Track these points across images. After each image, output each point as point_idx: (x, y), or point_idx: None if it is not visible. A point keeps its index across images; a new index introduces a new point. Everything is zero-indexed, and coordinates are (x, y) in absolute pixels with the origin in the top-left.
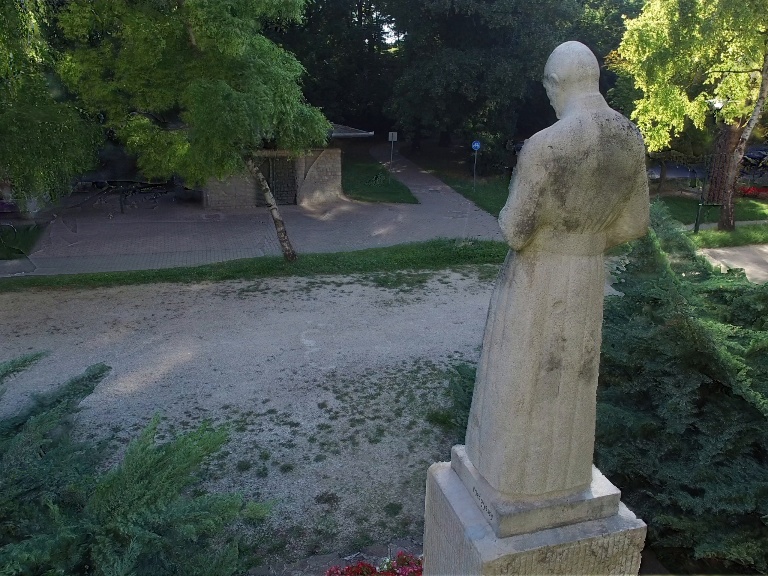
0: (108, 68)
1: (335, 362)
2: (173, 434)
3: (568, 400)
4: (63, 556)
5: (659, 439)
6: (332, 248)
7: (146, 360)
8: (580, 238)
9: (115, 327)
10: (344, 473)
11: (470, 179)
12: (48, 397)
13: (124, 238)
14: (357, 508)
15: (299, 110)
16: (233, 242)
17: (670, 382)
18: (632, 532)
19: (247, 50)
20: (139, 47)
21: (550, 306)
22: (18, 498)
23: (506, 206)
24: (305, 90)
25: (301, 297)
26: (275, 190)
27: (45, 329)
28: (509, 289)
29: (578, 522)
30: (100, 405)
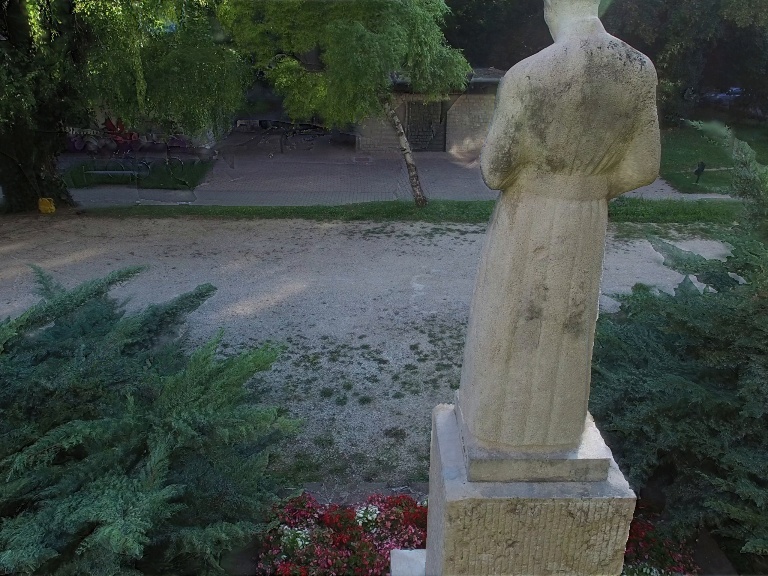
0: (259, 11)
1: (438, 307)
2: None
3: (548, 353)
4: (126, 438)
5: (739, 422)
6: (472, 197)
7: (266, 288)
8: (567, 180)
9: (247, 256)
10: (417, 412)
11: None
12: (160, 308)
13: (279, 176)
14: (421, 446)
15: (438, 52)
16: (376, 185)
17: (760, 361)
18: (617, 501)
19: None
20: None
21: (530, 251)
22: (108, 387)
23: (485, 142)
24: (447, 31)
25: (422, 242)
26: (409, 134)
27: (189, 252)
28: (492, 231)
29: (558, 481)
30: (218, 323)
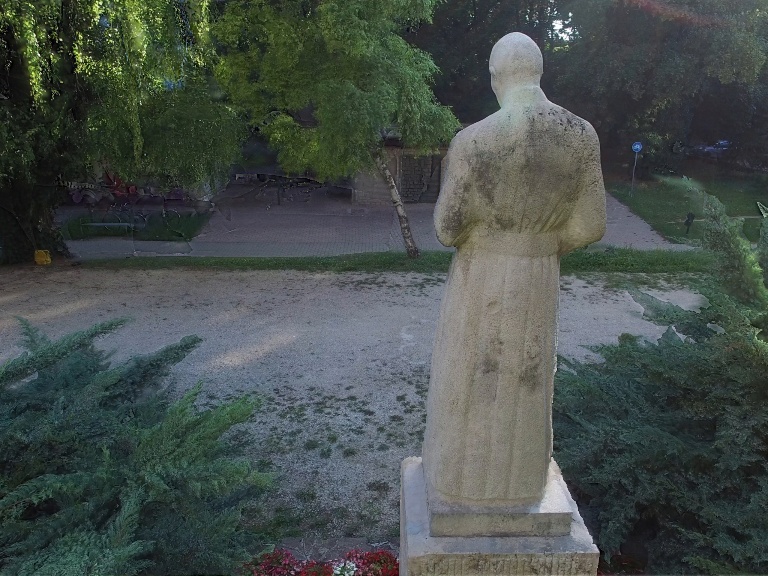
0: (254, 71)
1: (426, 358)
2: (258, 407)
3: (506, 406)
4: (99, 493)
5: (717, 474)
6: None
7: (255, 339)
8: (517, 237)
9: (238, 307)
10: None
11: (628, 183)
12: (145, 360)
13: (275, 228)
14: None
15: (427, 109)
16: (371, 236)
17: (735, 412)
18: (580, 556)
19: (378, 51)
20: (279, 51)
21: (484, 306)
22: (85, 440)
23: None
24: (436, 89)
25: (413, 293)
26: (401, 187)
27: (181, 303)
28: (448, 286)
29: (521, 535)
30: (205, 374)
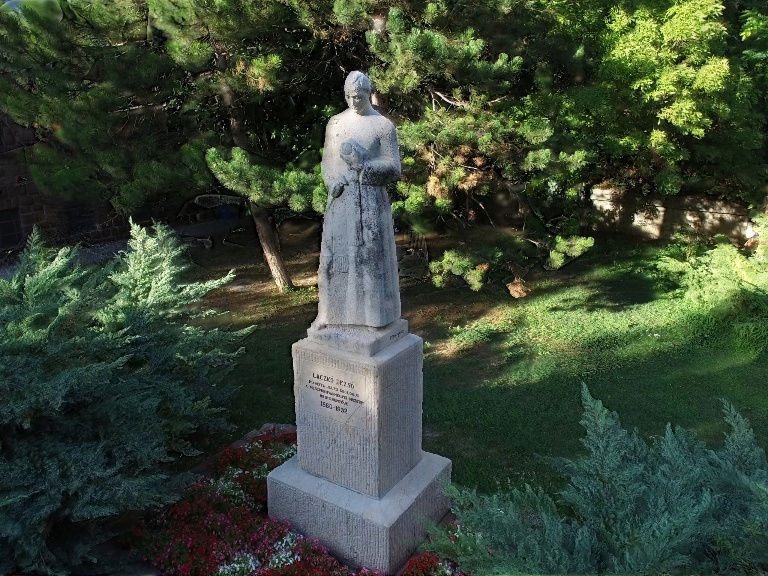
0: None
1: None
2: None
3: None
4: None
5: None
6: None
7: None
8: None
9: None
10: None
11: None
12: None
13: None
14: None
15: None
16: None
17: None
18: None
19: None
20: None
21: None
22: None
23: None
24: None
25: None
26: None
27: None
28: None
29: None
30: None
